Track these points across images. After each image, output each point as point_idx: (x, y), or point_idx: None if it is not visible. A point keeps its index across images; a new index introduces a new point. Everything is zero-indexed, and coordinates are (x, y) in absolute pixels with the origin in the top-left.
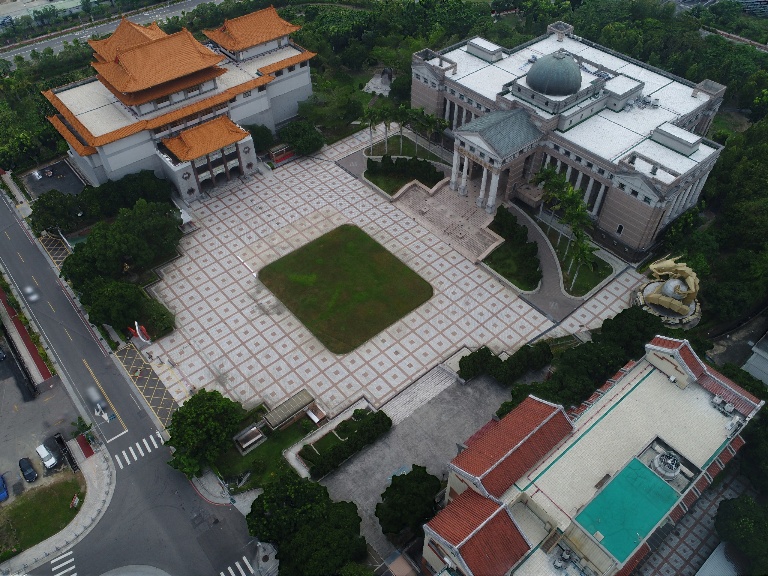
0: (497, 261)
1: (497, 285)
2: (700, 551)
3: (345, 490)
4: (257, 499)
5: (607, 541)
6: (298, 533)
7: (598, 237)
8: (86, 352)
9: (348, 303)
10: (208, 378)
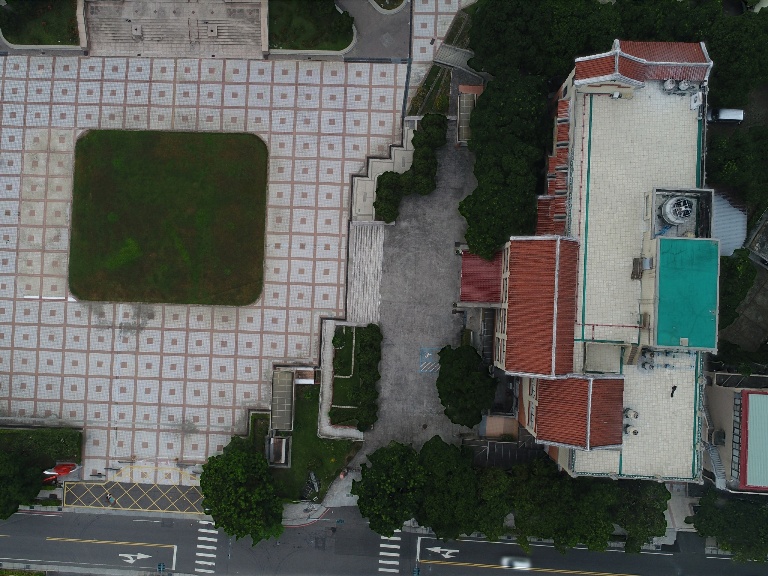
0: (284, 34)
1: (312, 67)
2: None
3: (399, 414)
4: (363, 510)
5: (693, 340)
6: (428, 509)
7: None
8: (38, 531)
9: (200, 239)
10: (175, 440)
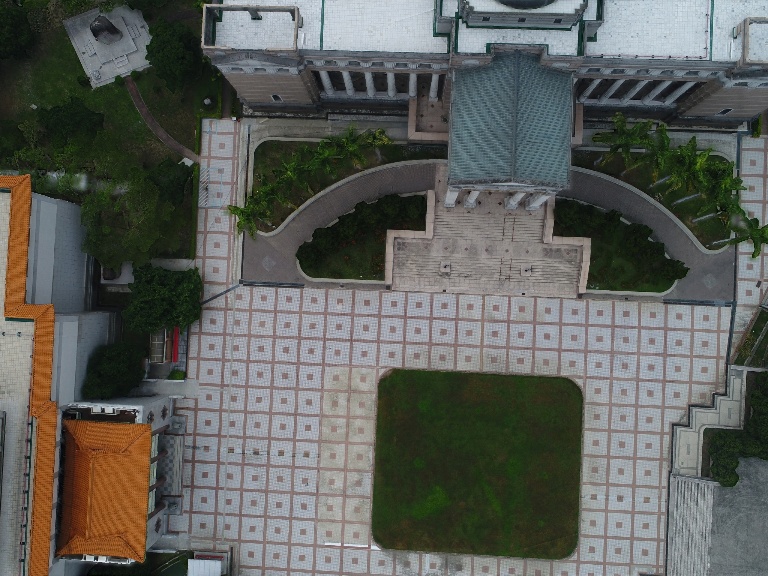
0: (603, 275)
1: (629, 308)
2: None
3: None
4: None
5: None
6: None
7: (678, 122)
8: None
9: (512, 488)
10: None
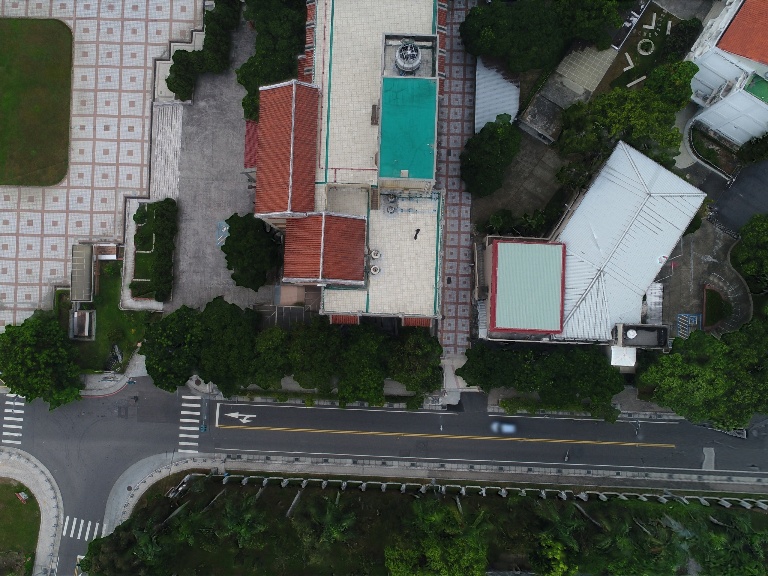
0: None
1: None
2: (467, 75)
3: (197, 285)
4: None
5: (412, 172)
6: (203, 361)
7: None
8: None
9: (6, 121)
10: None
